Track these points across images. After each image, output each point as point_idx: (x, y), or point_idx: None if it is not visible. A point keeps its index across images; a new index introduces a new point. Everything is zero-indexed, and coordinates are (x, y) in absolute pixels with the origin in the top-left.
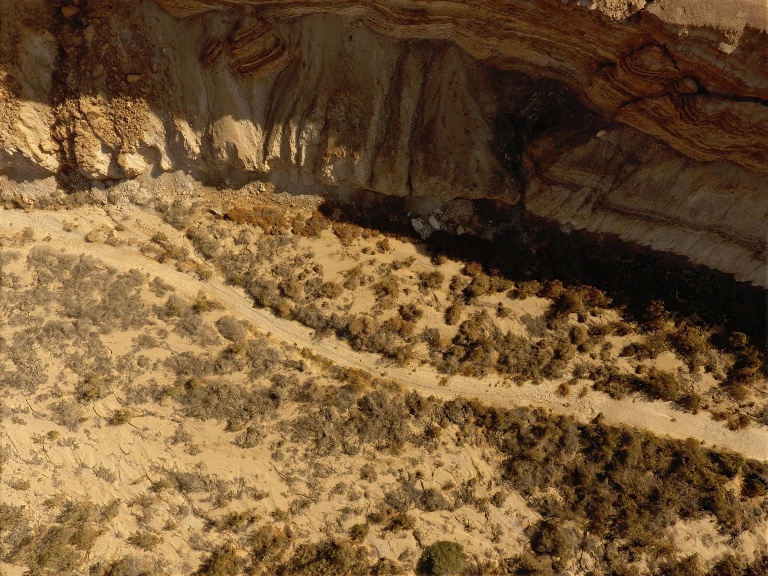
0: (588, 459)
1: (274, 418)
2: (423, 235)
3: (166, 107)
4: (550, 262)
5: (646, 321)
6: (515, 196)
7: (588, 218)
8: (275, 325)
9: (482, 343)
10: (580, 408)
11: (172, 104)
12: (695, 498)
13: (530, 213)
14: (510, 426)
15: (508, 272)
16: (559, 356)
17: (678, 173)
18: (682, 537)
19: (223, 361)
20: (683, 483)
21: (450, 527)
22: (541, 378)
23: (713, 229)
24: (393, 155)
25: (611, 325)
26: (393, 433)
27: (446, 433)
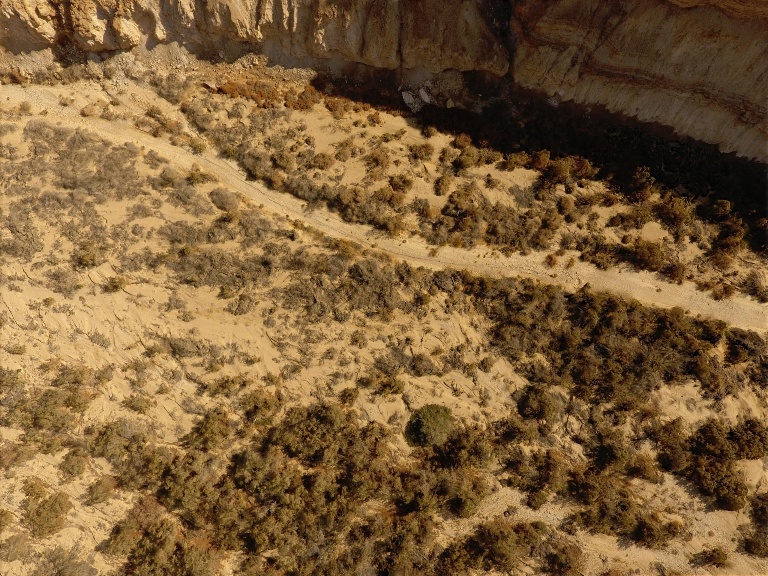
0: (574, 325)
1: (266, 285)
2: (413, 109)
3: None
4: (538, 135)
5: (632, 191)
6: (503, 64)
7: (575, 85)
8: (268, 197)
9: (471, 213)
10: (567, 279)
11: None
12: (679, 362)
13: (519, 85)
14: (498, 294)
15: (497, 144)
16: (546, 225)
17: (662, 22)
18: (666, 401)
19: (216, 229)
20: (668, 348)
21: (438, 391)
22: (529, 249)
23: (697, 88)
24: (383, 15)
25: (598, 196)
26: (383, 299)
27: (435, 300)
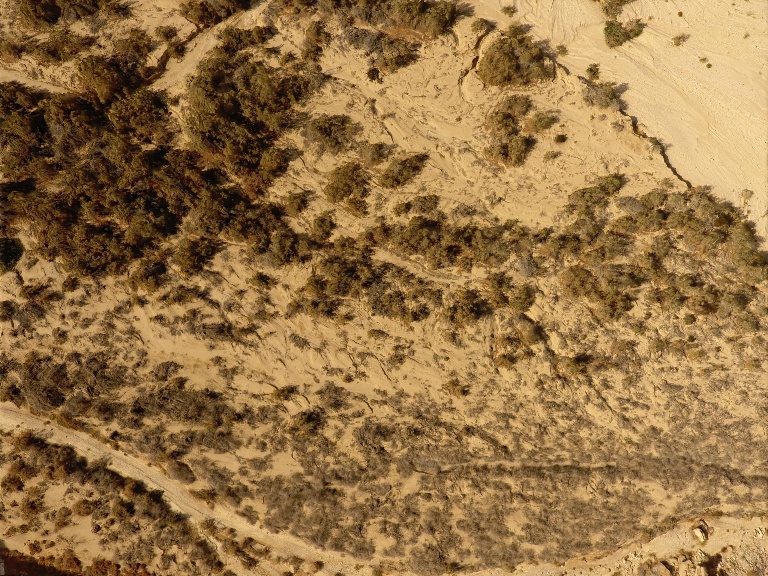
0: None
1: (142, 389)
2: None
3: None
4: None
5: None
6: None
7: None
8: (144, 473)
9: None
10: None
11: None
12: None
13: None
14: None
15: None
16: None
17: None
18: None
19: (186, 444)
20: None
21: None
22: None
23: None
24: None
25: None
26: (33, 373)
27: None
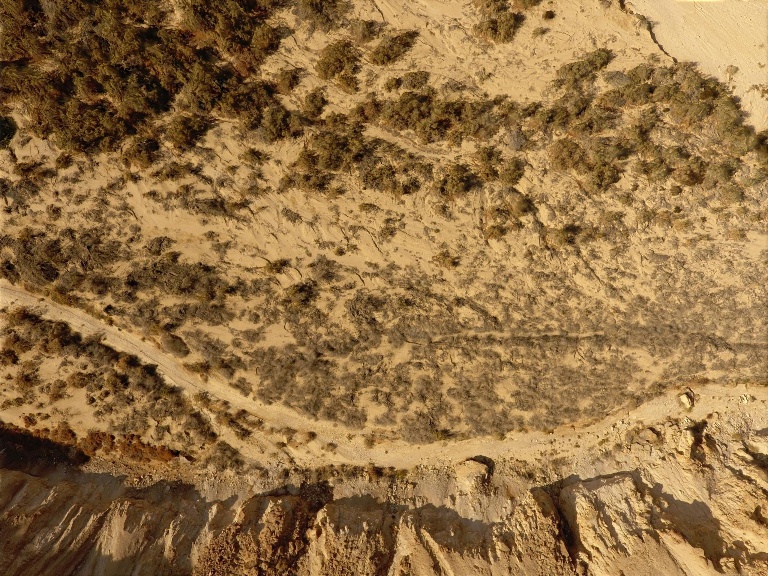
0: None
1: (135, 264)
2: None
3: (175, 571)
4: None
5: None
6: None
7: None
8: (138, 348)
9: None
10: None
11: (168, 574)
12: None
13: None
14: None
15: None
16: None
17: None
18: None
19: (179, 317)
20: None
21: None
22: None
23: None
24: None
25: None
26: (27, 248)
27: None
